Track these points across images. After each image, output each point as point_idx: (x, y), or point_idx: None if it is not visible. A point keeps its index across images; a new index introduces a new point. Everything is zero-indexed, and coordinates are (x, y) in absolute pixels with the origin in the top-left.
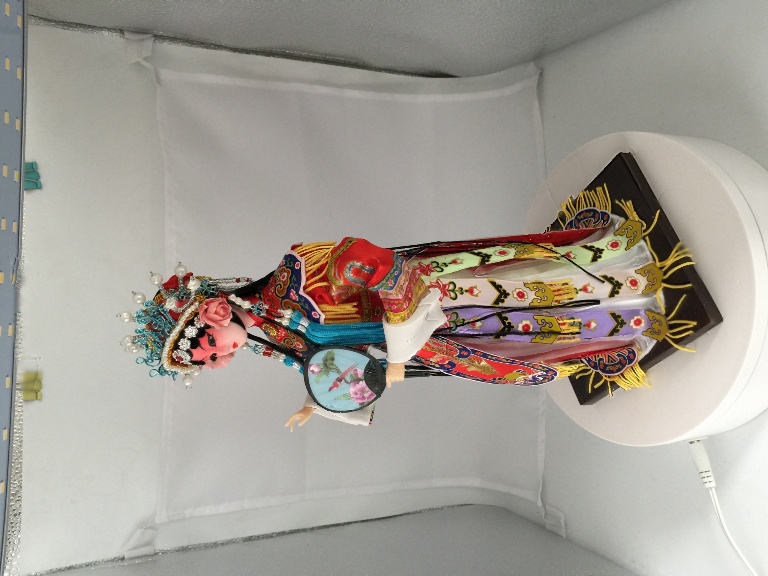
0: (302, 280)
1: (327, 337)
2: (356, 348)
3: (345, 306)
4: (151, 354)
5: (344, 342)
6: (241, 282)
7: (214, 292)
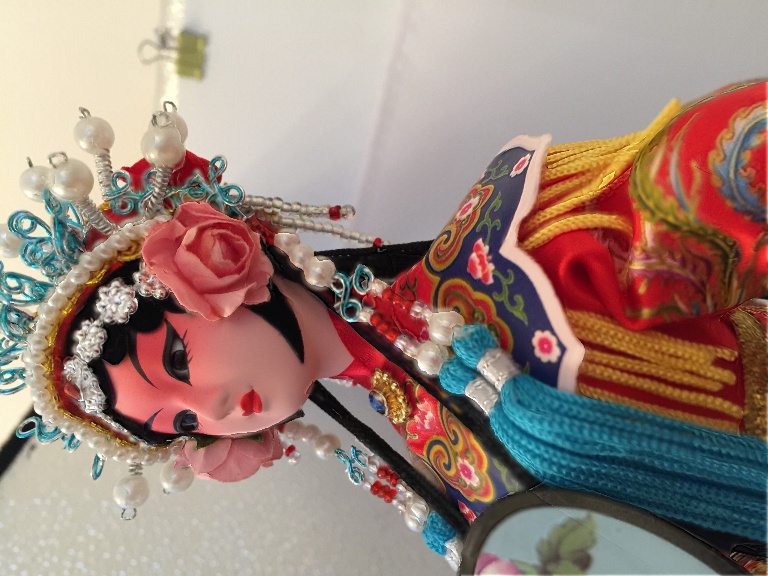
0: (521, 201)
1: (575, 450)
2: (705, 540)
3: (680, 347)
4: (8, 350)
5: (648, 500)
6: (355, 246)
7: (238, 211)
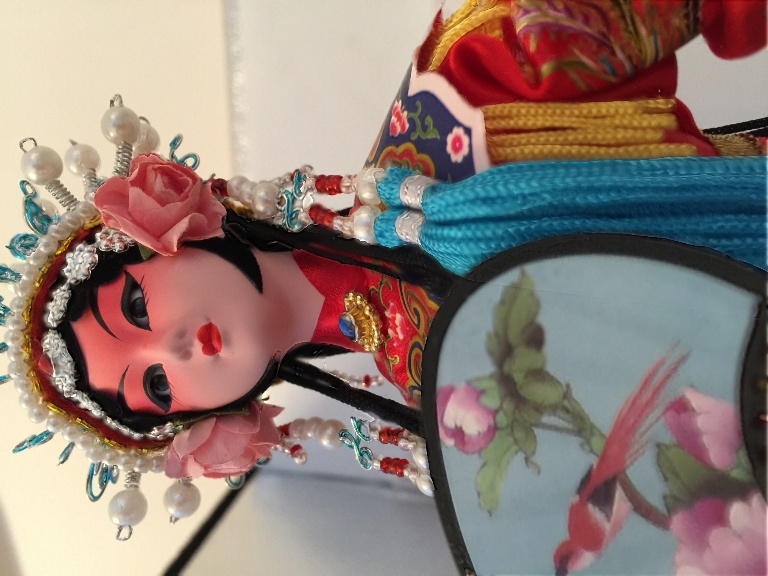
0: None
1: (497, 215)
2: None
3: (602, 105)
4: None
5: None
6: None
7: None
